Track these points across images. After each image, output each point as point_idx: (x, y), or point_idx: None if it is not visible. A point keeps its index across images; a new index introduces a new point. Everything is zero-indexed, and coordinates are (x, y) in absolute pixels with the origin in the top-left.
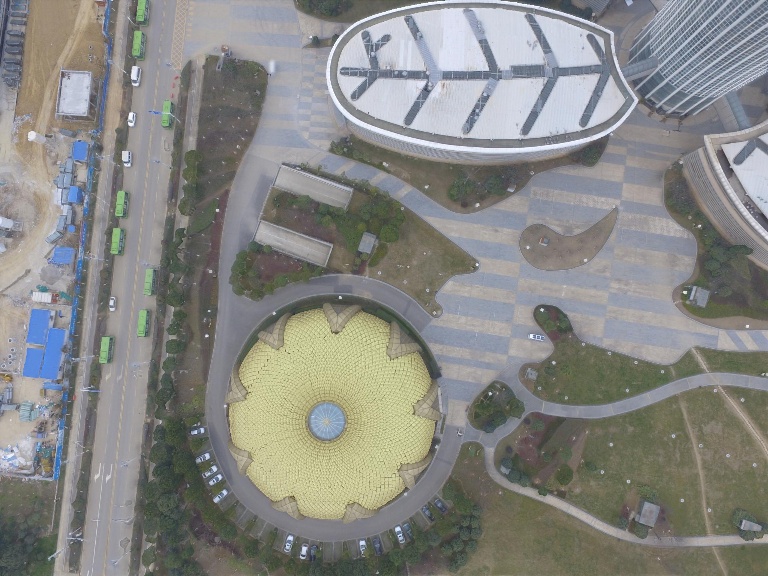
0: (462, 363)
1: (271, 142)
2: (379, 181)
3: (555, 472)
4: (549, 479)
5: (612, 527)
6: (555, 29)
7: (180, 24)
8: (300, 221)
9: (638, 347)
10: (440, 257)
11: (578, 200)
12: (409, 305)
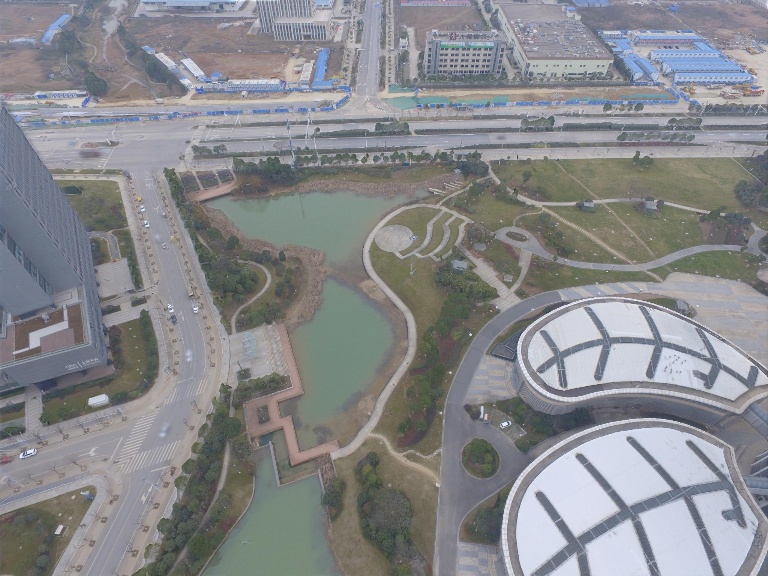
0: None
1: None
2: None
3: (711, 221)
4: None
5: None
6: None
7: None
8: None
9: (700, 281)
10: None
11: None
12: None
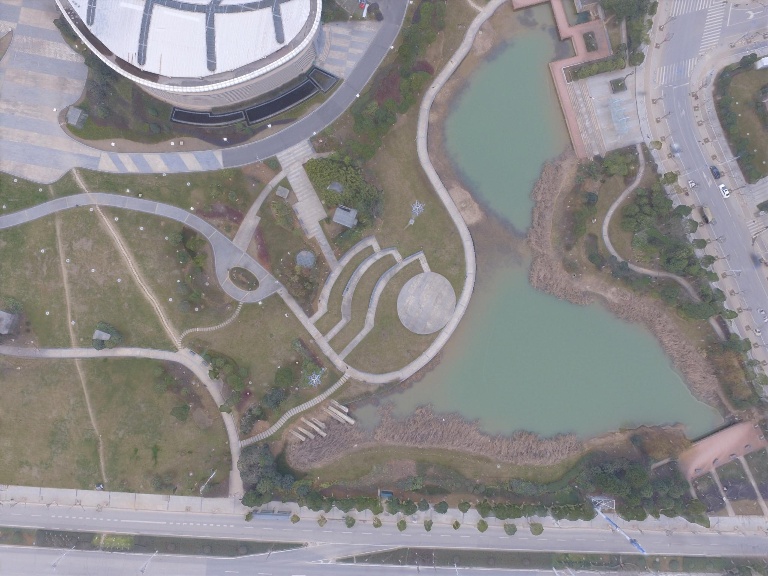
0: None
1: None
2: None
3: None
4: None
5: None
6: None
7: None
8: None
9: (20, 166)
10: None
11: None
12: None
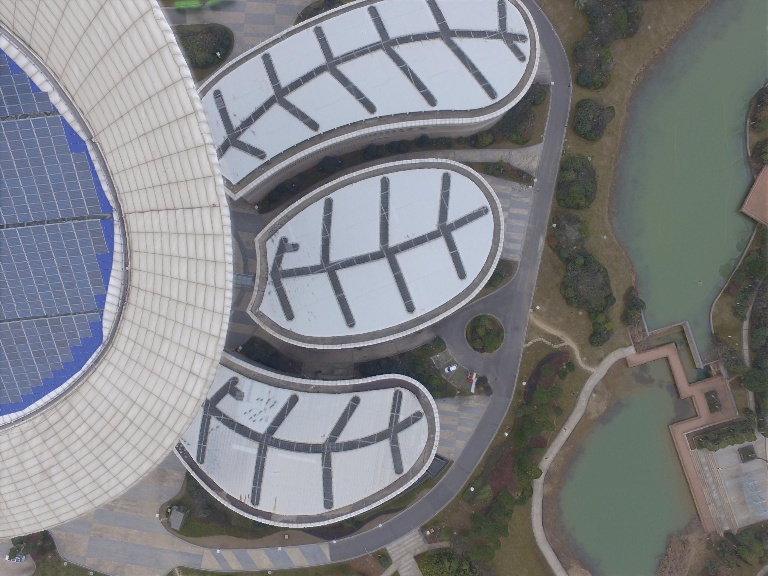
0: None
1: None
2: None
3: None
4: None
5: None
6: None
7: None
8: None
9: (121, 567)
10: None
11: None
12: None
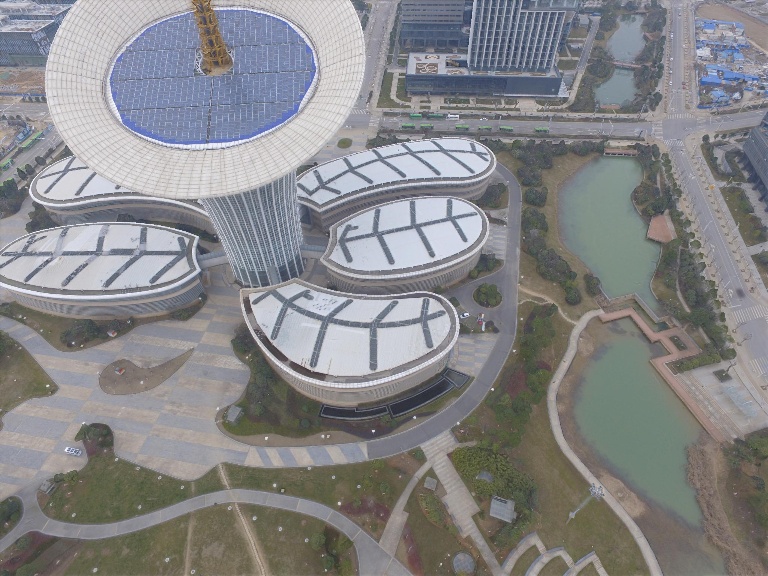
0: None
1: None
2: (15, 330)
3: None
4: None
5: None
6: (157, 234)
7: None
8: None
9: (168, 463)
10: (27, 384)
11: (165, 343)
12: None
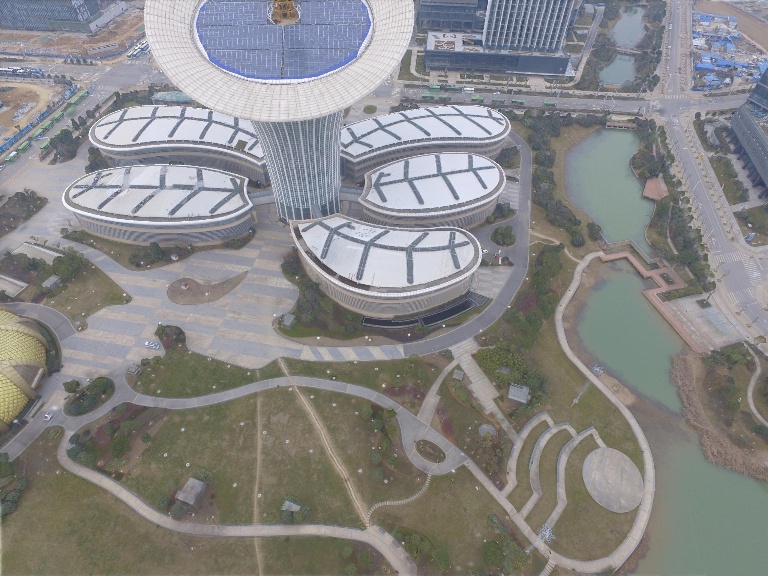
0: (83, 363)
1: (26, 232)
2: (86, 253)
3: None
4: (112, 460)
5: (156, 513)
6: (211, 174)
7: (11, 181)
8: (14, 271)
9: (235, 356)
10: (104, 294)
11: (221, 266)
12: (63, 323)
